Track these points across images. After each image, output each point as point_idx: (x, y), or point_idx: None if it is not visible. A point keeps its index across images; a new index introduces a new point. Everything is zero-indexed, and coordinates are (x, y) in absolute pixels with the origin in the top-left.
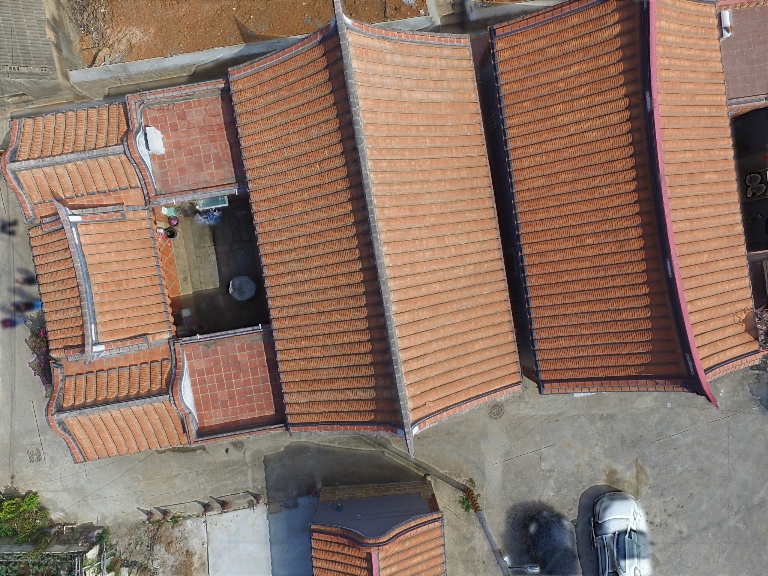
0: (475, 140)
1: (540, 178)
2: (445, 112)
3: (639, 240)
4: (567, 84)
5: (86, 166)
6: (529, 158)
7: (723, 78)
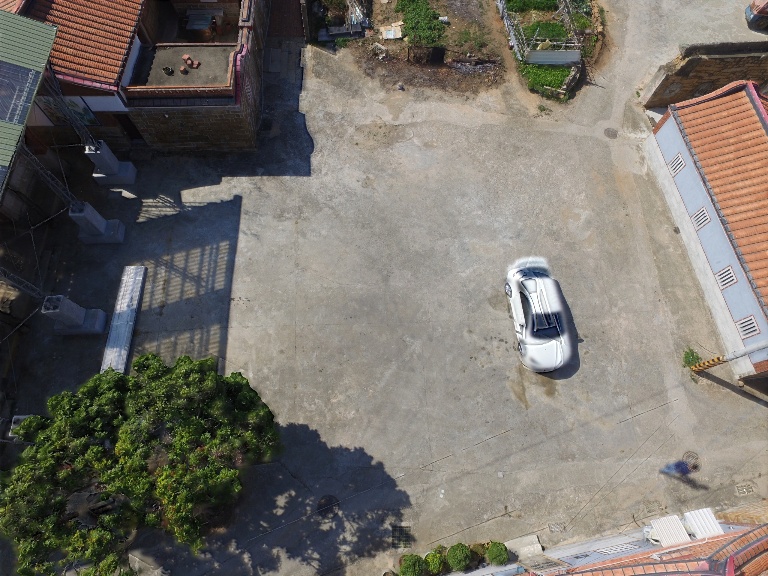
0: None
1: None
2: None
3: None
4: None
5: None
6: None
7: None
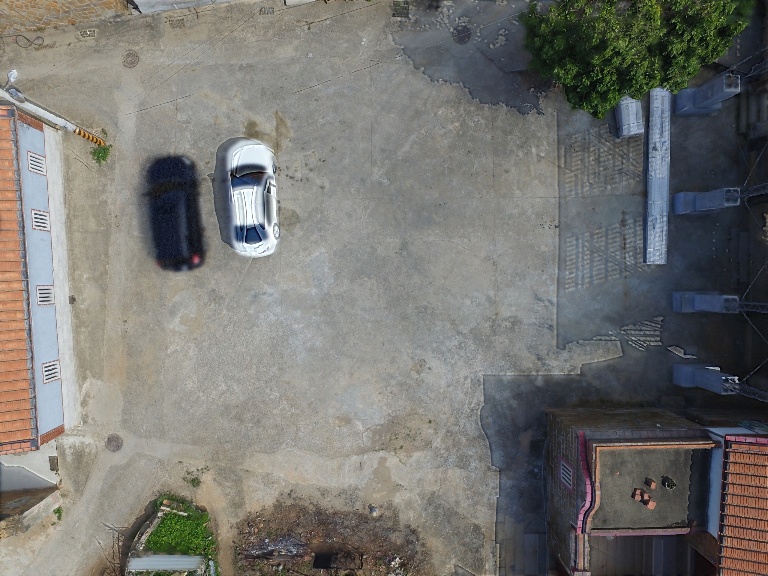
0: None
1: None
2: None
3: None
4: None
5: None
6: None
7: None
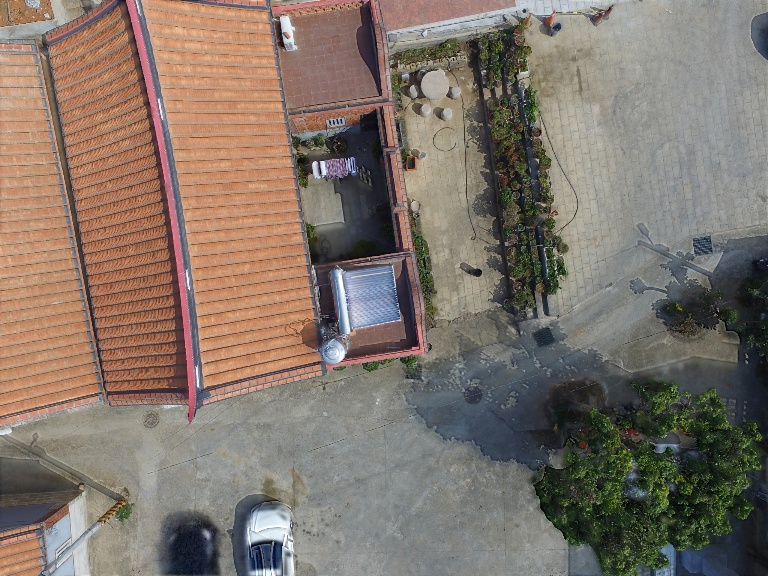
0: (43, 148)
1: (92, 187)
2: (3, 119)
3: (166, 251)
4: (103, 91)
5: None
6: (83, 167)
7: (278, 85)
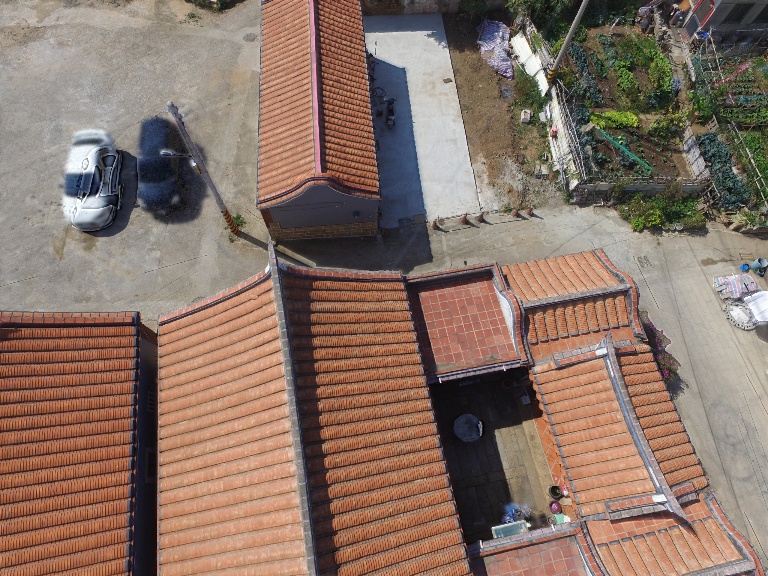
0: None
1: None
2: None
3: None
4: None
5: (664, 571)
6: None
7: None
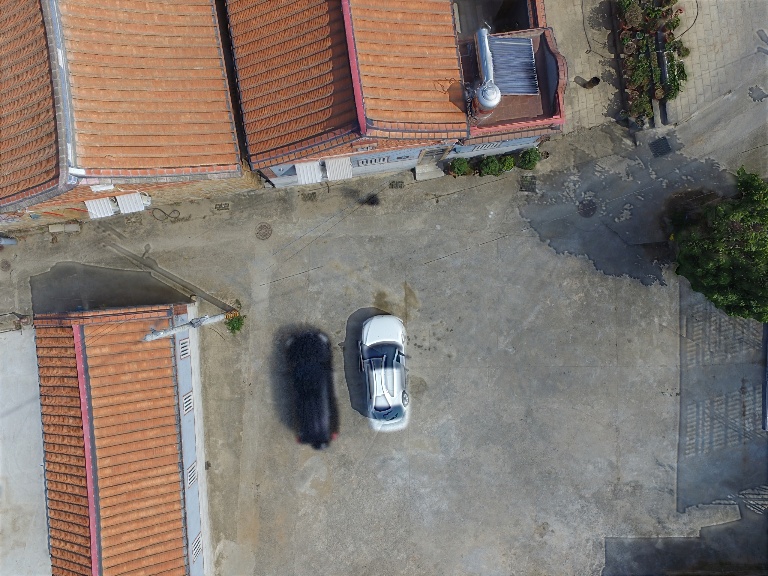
0: None
1: None
2: None
3: None
4: None
5: None
6: None
7: None
